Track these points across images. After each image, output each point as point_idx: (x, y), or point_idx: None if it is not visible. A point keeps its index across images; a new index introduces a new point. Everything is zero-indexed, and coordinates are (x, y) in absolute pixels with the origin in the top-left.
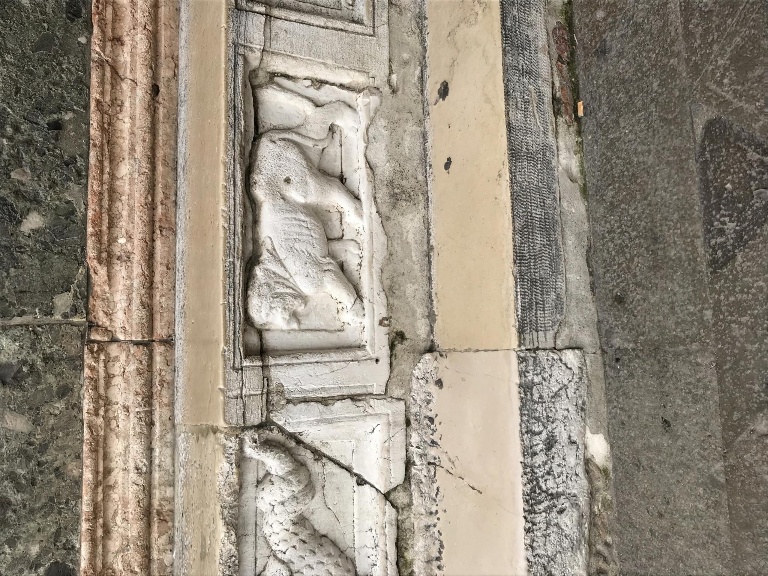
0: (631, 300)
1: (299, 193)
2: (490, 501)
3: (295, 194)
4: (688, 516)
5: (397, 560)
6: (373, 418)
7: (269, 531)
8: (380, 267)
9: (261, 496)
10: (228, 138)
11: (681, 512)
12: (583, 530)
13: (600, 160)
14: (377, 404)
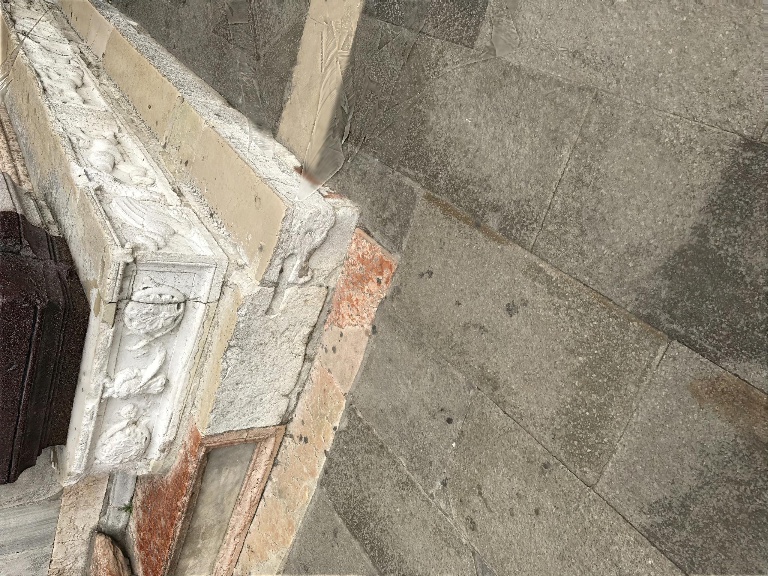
0: (127, 2)
1: (28, 21)
2: (99, 28)
3: (27, 21)
4: (145, 1)
5: (82, 59)
6: (65, 45)
7: (32, 49)
8: (61, 33)
9: (27, 45)
10: (2, 10)
11: (144, 2)
12: (129, 25)
13: (115, 0)
14: (66, 44)
